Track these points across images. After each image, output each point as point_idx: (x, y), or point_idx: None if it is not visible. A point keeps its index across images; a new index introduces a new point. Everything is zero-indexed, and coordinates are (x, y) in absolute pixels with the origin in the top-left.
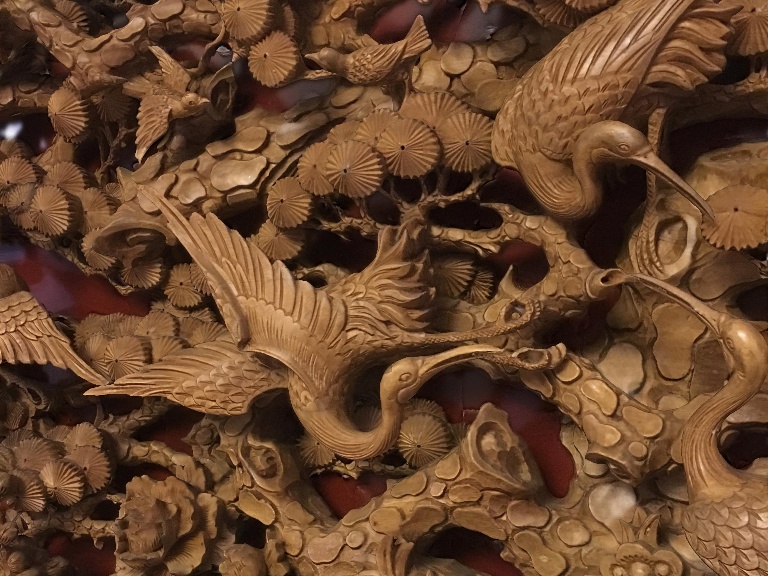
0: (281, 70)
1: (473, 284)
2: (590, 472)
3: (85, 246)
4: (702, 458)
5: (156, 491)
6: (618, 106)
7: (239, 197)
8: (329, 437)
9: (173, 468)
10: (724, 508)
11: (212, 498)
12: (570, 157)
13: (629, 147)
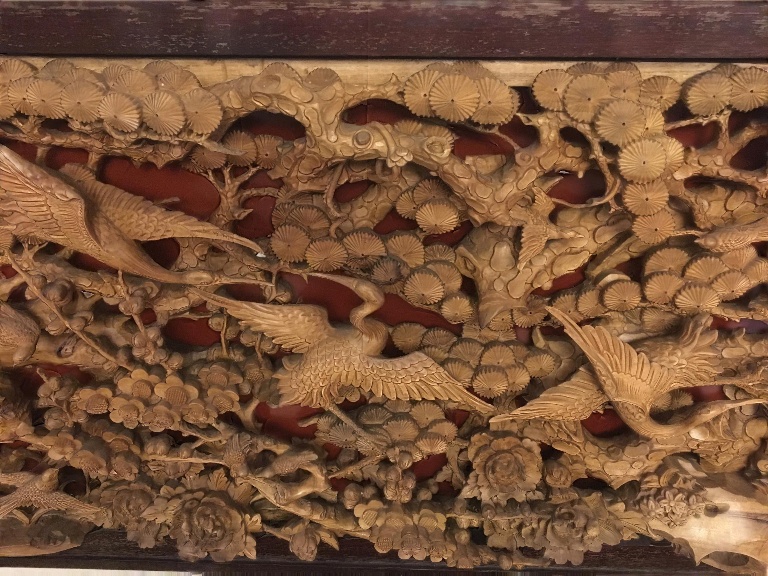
0: (662, 237)
1: None
2: (747, 414)
3: (447, 309)
4: None
5: (496, 443)
6: None
7: (564, 274)
8: (647, 432)
9: (474, 411)
10: None
11: (533, 442)
12: None
13: None
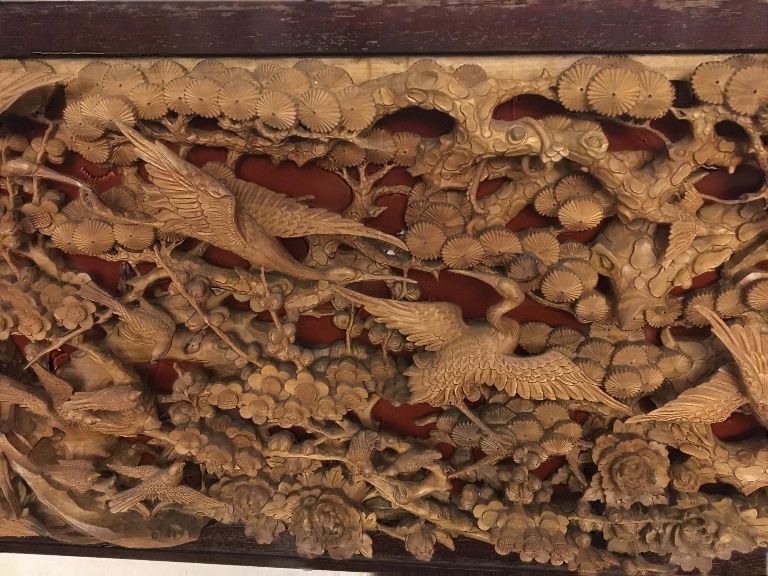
0: None
1: None
2: None
3: (583, 308)
4: None
5: (622, 445)
6: None
7: None
8: None
9: None
10: None
11: (660, 445)
12: None
13: None
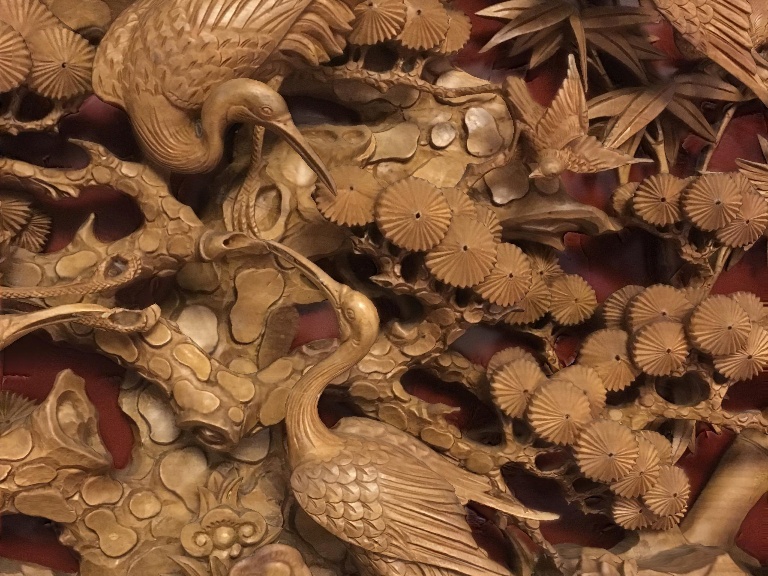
0: None
1: (26, 229)
2: (160, 439)
3: None
4: (308, 421)
5: None
6: (252, 65)
7: None
8: None
9: None
10: (334, 466)
11: None
12: (195, 107)
13: (272, 111)
